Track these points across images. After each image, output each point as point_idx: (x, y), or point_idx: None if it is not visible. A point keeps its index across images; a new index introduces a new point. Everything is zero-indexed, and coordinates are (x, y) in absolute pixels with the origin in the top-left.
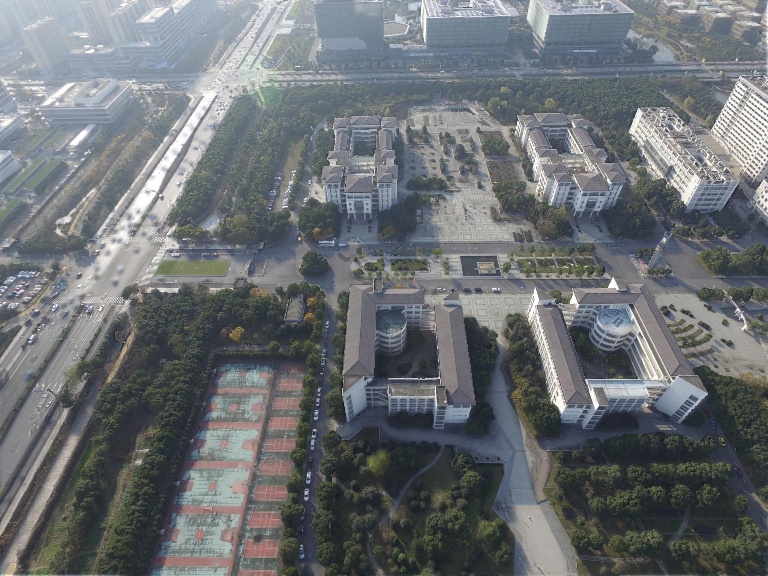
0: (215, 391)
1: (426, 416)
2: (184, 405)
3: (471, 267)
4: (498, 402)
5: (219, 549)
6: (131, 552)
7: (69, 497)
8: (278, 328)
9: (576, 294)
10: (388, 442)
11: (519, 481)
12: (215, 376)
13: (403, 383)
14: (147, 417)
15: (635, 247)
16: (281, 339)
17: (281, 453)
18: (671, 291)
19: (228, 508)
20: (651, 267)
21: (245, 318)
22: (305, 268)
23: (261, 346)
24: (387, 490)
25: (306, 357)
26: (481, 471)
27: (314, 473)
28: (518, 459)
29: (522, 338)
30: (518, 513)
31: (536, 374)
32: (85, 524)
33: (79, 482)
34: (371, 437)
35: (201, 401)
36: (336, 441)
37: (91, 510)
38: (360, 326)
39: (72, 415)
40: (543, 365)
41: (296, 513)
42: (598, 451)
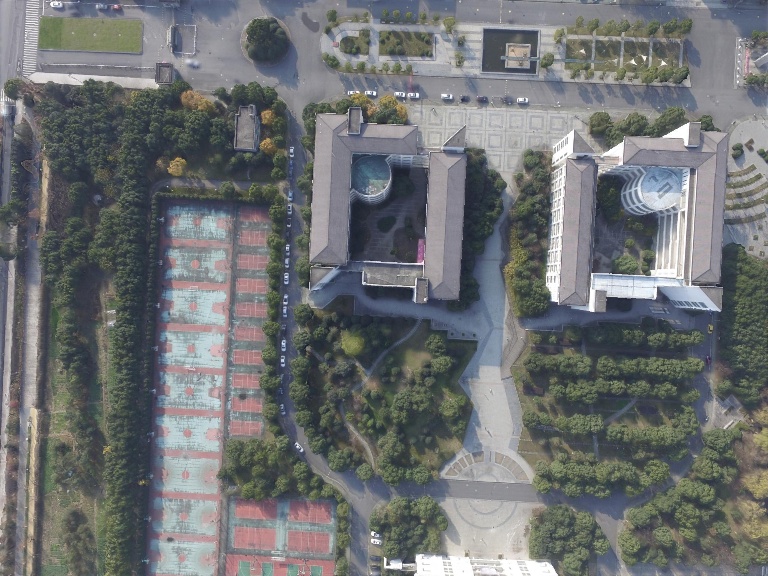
0: (169, 243)
1: (405, 292)
2: (138, 270)
3: (496, 53)
4: (488, 272)
5: (209, 404)
6: (131, 413)
7: (56, 353)
8: (228, 161)
9: (626, 148)
10: (363, 318)
11: (489, 358)
12: (165, 223)
13: (380, 267)
14: (103, 273)
15: (754, 21)
16: (235, 173)
17: (254, 319)
18: (763, 115)
19: (210, 370)
20: (758, 66)
21: (182, 147)
22: (253, 50)
23: (212, 182)
24: (360, 362)
25: (269, 204)
26: (454, 347)
27: (289, 341)
28: (494, 337)
29: (536, 193)
30: (481, 387)
31: (539, 246)
32: (81, 383)
33: (59, 346)
34: (346, 306)
35: (156, 259)
36: (308, 318)
37: (81, 372)
38: (329, 193)
39: (20, 267)
40: (551, 231)
41: (273, 387)
42: (577, 341)
